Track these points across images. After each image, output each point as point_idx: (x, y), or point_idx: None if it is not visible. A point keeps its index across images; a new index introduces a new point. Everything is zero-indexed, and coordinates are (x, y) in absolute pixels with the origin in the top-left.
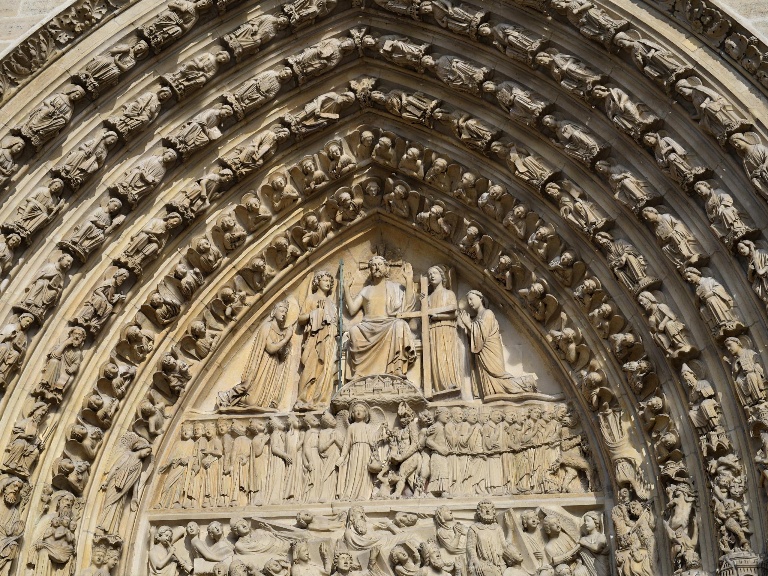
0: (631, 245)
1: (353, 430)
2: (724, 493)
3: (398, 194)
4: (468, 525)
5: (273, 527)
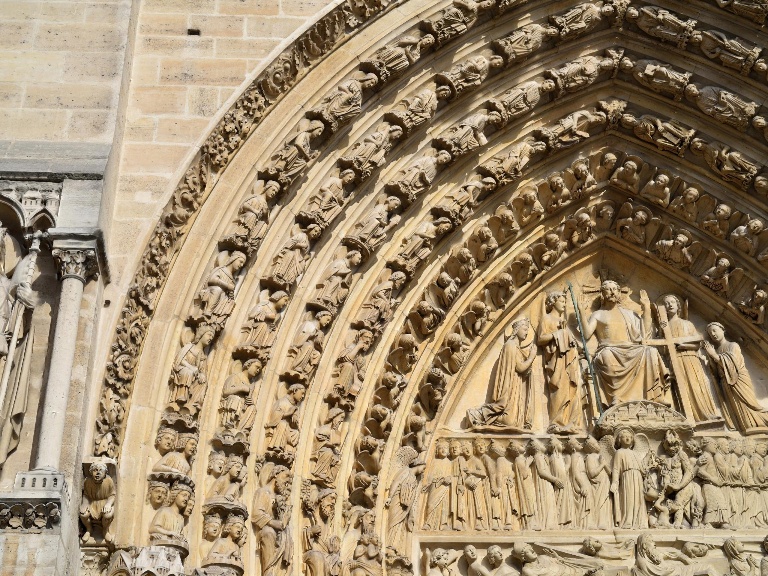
0: None
1: (623, 456)
2: None
3: (641, 220)
4: (757, 557)
5: (559, 553)
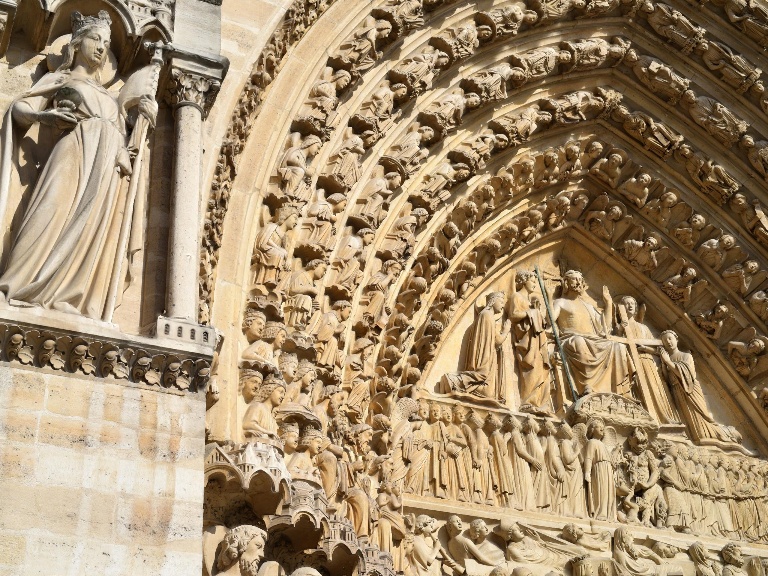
0: None
1: (597, 446)
2: None
3: (616, 214)
4: None
5: (541, 536)
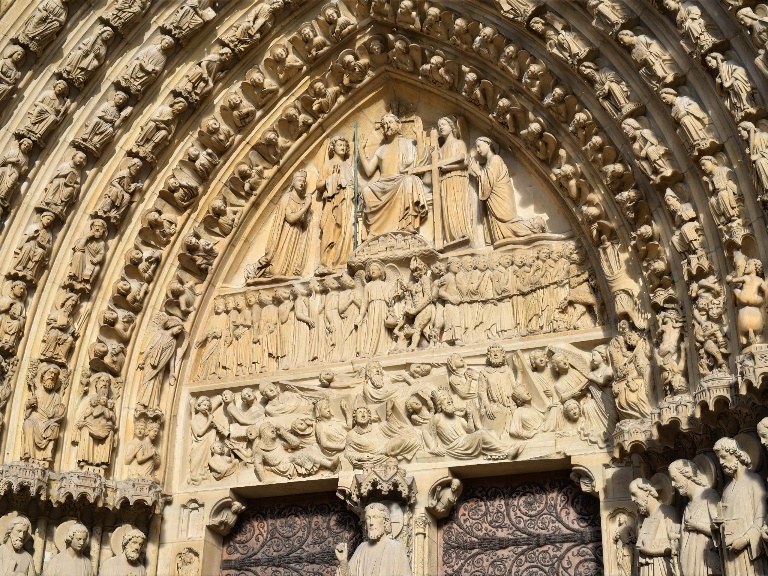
0: (614, 72)
1: (369, 289)
2: (703, 316)
3: (399, 49)
4: (480, 370)
5: (299, 388)
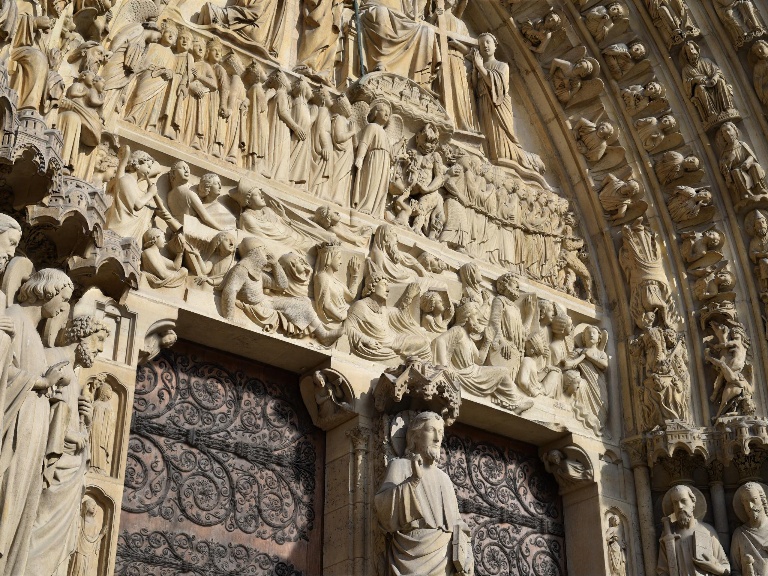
0: None
1: (377, 131)
2: None
3: None
4: None
5: (287, 212)
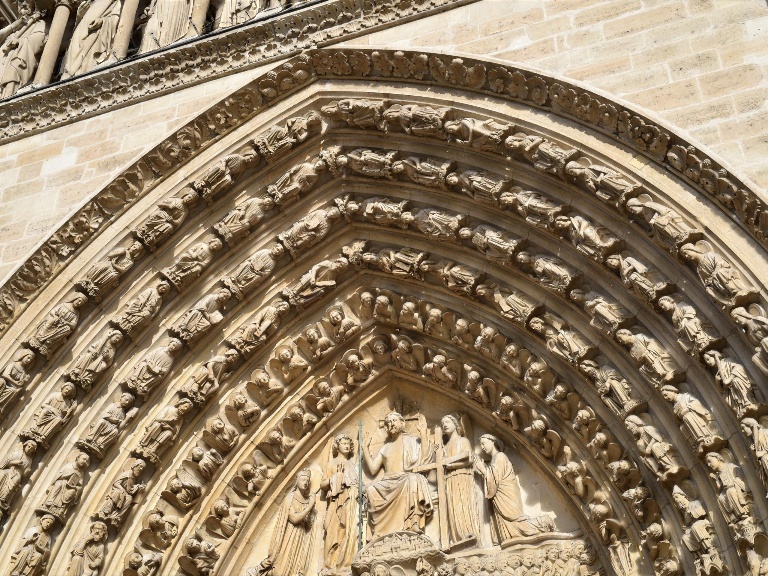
0: (614, 370)
1: None
2: None
3: (402, 349)
4: None
5: None
